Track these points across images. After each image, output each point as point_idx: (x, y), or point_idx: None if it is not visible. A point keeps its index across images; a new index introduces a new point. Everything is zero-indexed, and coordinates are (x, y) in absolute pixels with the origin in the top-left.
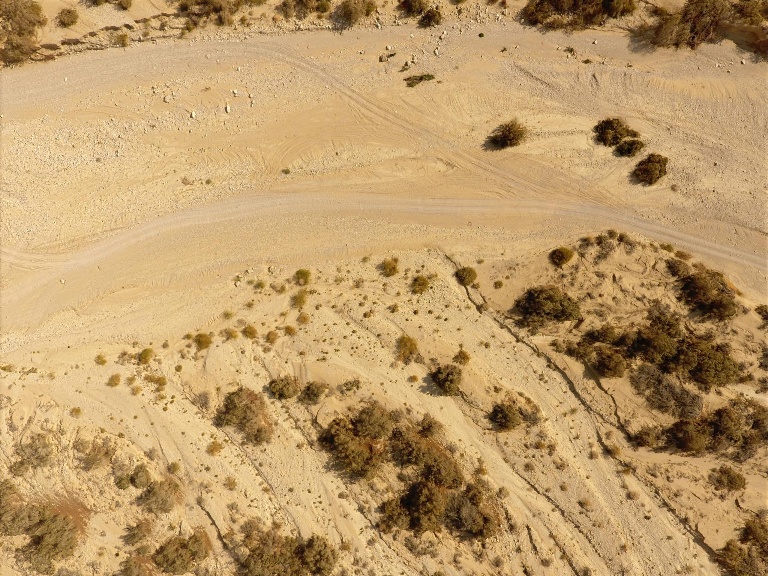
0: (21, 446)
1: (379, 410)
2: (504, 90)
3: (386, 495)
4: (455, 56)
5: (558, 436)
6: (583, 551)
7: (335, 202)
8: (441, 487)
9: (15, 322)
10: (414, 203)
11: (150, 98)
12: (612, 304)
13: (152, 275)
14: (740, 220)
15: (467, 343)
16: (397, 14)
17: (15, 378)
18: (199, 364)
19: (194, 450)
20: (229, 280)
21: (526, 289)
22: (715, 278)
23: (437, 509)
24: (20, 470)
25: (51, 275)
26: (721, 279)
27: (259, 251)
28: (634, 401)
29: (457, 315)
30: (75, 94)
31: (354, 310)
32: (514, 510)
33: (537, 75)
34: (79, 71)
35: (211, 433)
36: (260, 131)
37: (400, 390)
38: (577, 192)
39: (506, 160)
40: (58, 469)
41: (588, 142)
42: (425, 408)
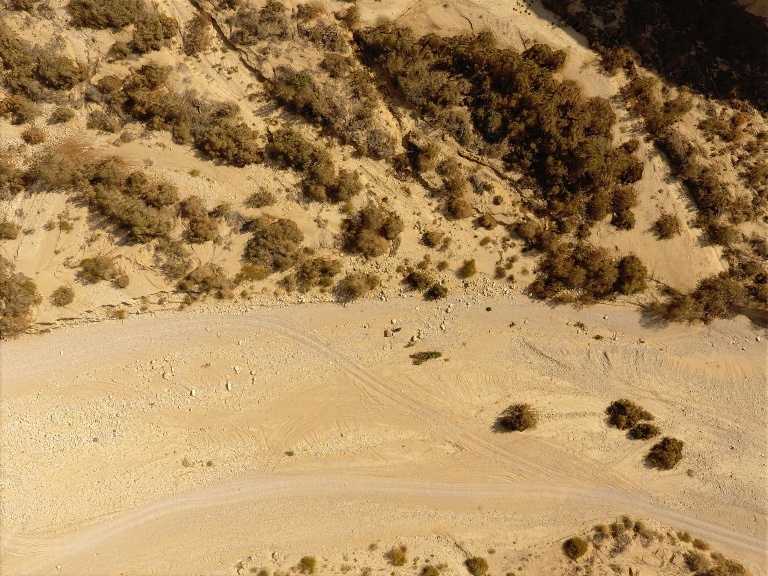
0: None
1: None
2: (513, 369)
3: None
4: (462, 331)
5: None
6: None
7: (340, 485)
8: None
9: None
10: (422, 487)
11: (149, 374)
12: None
13: (152, 562)
14: (759, 507)
15: None
16: (402, 287)
17: None
18: None
19: None
20: (231, 567)
21: None
22: (735, 574)
23: None
24: None
25: (47, 560)
26: (741, 575)
27: (262, 537)
28: None
29: None
30: (71, 368)
31: None
32: None
33: (547, 353)
34: (75, 344)
35: None
36: (262, 410)
37: None
38: (590, 476)
39: (516, 443)
40: None
41: (601, 425)
42: None
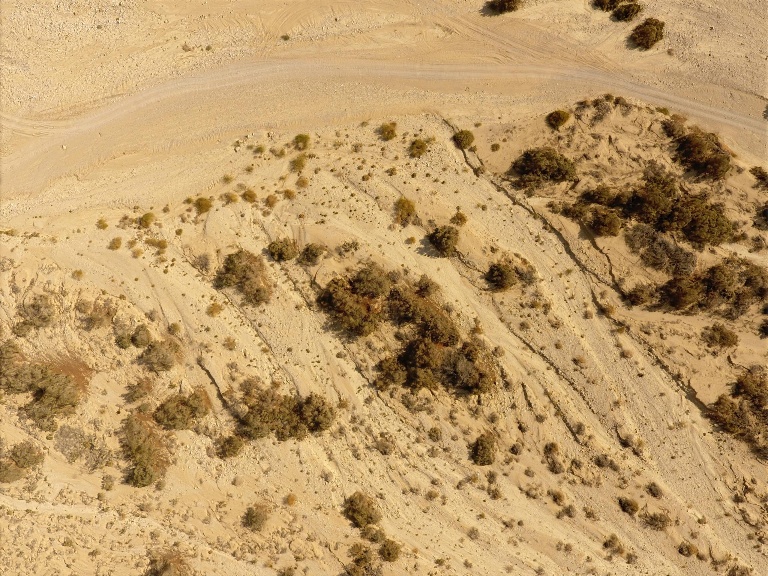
0: (24, 307)
1: (377, 271)
2: None
3: (383, 353)
4: None
5: (553, 296)
6: (577, 408)
7: (334, 68)
8: (438, 344)
9: (17, 188)
10: (412, 69)
11: None
12: (608, 165)
13: (153, 141)
14: (735, 84)
15: (464, 205)
16: None
17: (17, 242)
18: (199, 228)
19: (194, 311)
20: (229, 145)
21: (523, 151)
22: (710, 138)
23: (433, 361)
24: (23, 329)
25: (53, 141)
26: (716, 140)
27: (259, 116)
28: (629, 259)
29: (454, 178)
30: None
31: (352, 173)
32: (509, 368)
33: None
34: None
35: (211, 295)
36: None
37: (398, 252)
38: (574, 57)
39: (504, 25)
40: (60, 330)
41: (585, 7)
42: (422, 269)
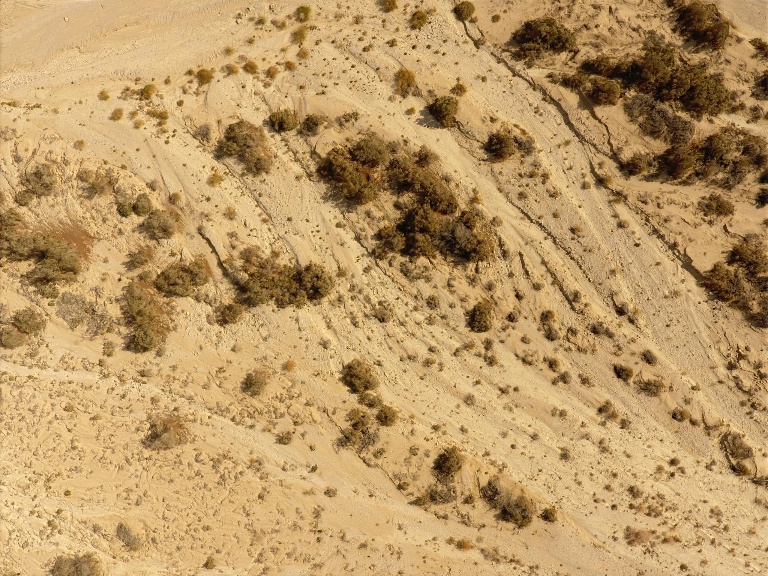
0: (26, 176)
1: (377, 141)
2: None
3: (382, 222)
4: None
5: (552, 167)
6: (574, 277)
7: None
8: (436, 213)
9: (19, 60)
10: None
11: None
12: (608, 35)
13: (154, 13)
14: None
15: (464, 77)
16: None
17: (20, 112)
18: (200, 99)
19: (195, 181)
20: (230, 18)
21: (523, 22)
22: (710, 8)
23: (432, 224)
24: (25, 197)
25: (55, 13)
26: (716, 10)
27: None
28: (627, 128)
29: (455, 50)
30: None
31: (353, 44)
32: (507, 238)
33: None
34: None
35: (212, 166)
36: None
37: (398, 123)
38: None
39: None
40: (62, 199)
41: None
42: (422, 140)
